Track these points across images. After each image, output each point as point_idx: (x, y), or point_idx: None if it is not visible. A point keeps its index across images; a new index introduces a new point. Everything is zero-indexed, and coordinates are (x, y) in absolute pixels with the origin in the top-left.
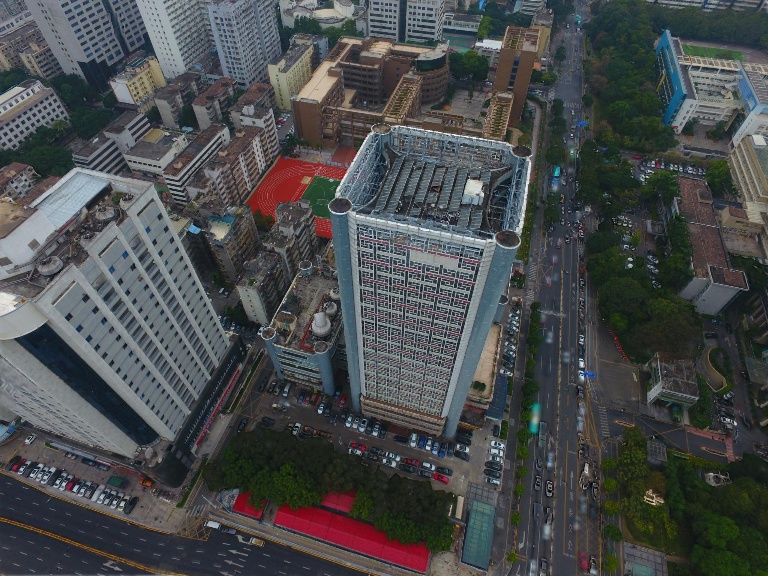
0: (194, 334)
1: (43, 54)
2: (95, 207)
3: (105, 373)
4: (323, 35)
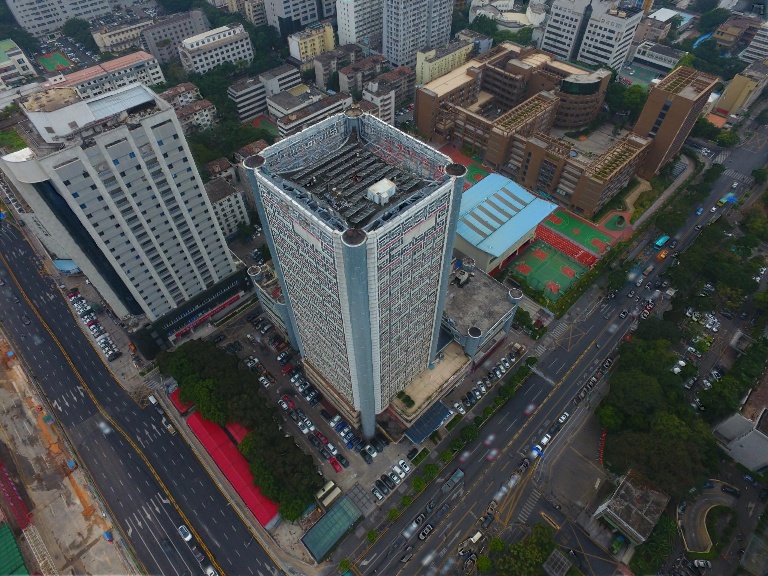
0: (195, 245)
1: (260, 5)
2: (136, 114)
3: (94, 238)
4: (494, 36)
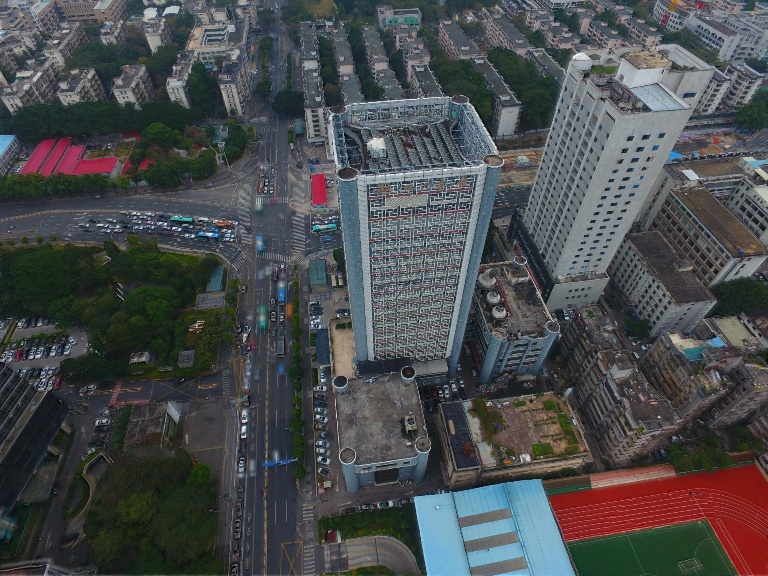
0: None
1: None
2: None
3: None
4: None
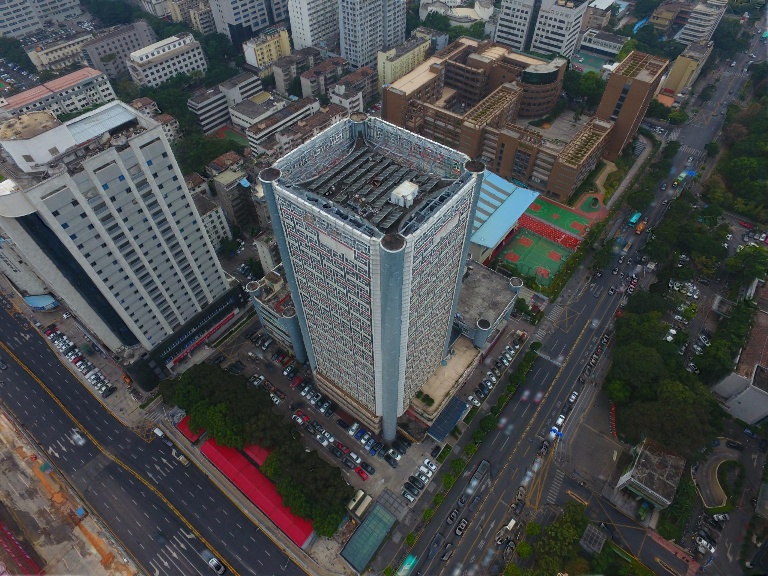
0: (189, 266)
1: (207, 13)
2: None
3: (86, 270)
4: (448, 32)
